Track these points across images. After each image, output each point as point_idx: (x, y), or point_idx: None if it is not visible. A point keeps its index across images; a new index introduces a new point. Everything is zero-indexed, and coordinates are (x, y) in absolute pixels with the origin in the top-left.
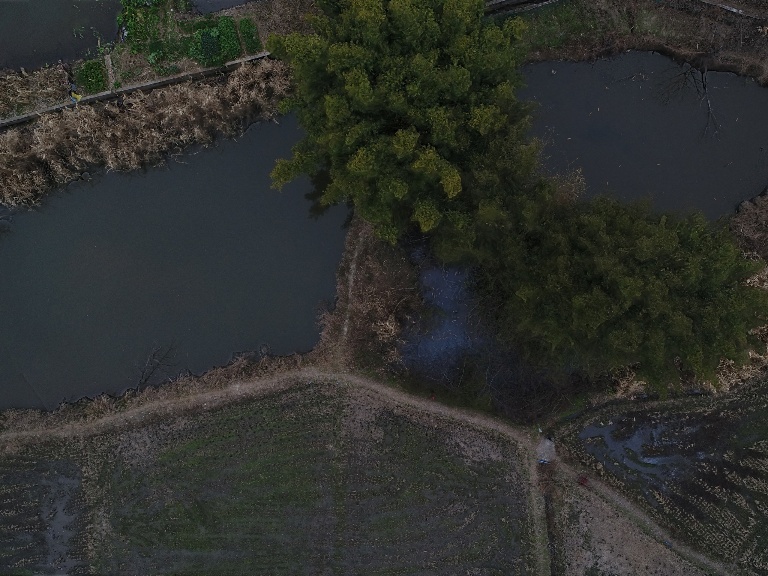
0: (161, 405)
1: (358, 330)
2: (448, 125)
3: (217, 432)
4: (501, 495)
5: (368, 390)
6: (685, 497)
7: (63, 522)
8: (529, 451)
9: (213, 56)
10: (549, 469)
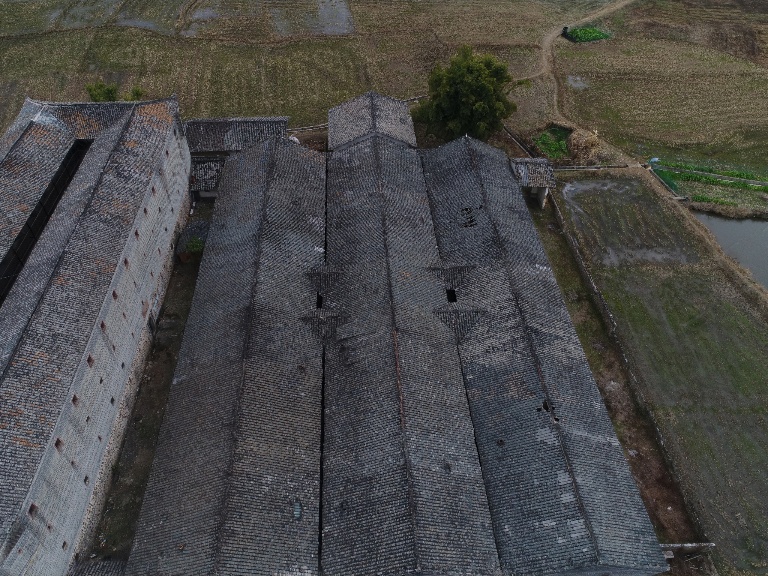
0: (767, 301)
1: None
2: None
3: (762, 333)
4: None
5: None
6: None
7: (656, 257)
8: None
9: None
10: None
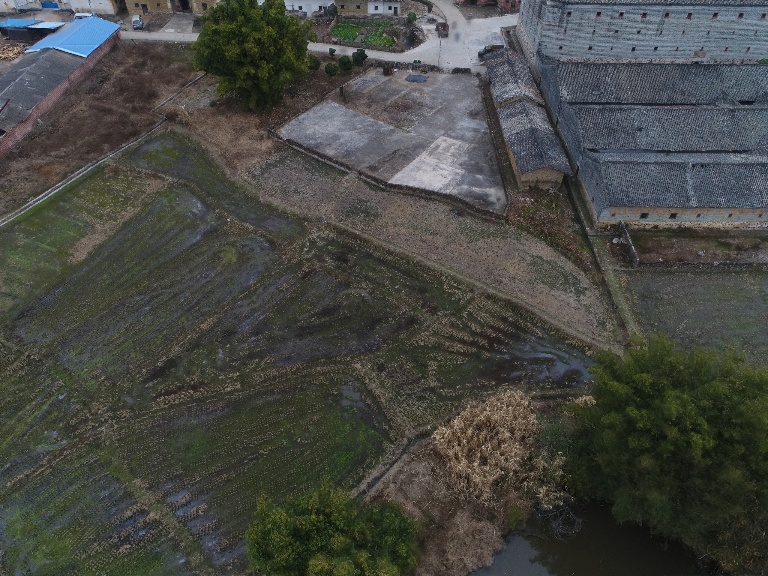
0: None
1: None
2: None
3: None
4: None
5: None
6: (517, 332)
7: None
8: None
9: None
10: None
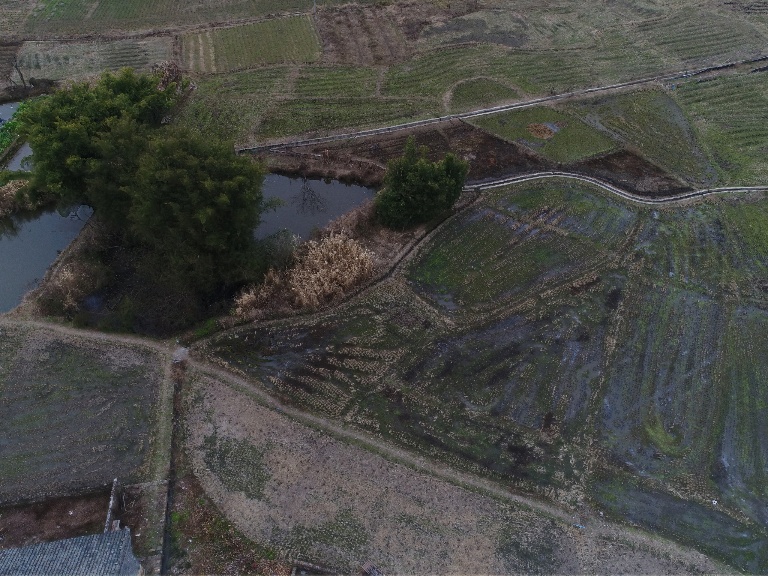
0: None
1: (50, 294)
2: (91, 123)
3: None
4: (138, 389)
5: (46, 330)
6: (296, 378)
7: None
8: (167, 356)
9: (5, 183)
10: (182, 366)
